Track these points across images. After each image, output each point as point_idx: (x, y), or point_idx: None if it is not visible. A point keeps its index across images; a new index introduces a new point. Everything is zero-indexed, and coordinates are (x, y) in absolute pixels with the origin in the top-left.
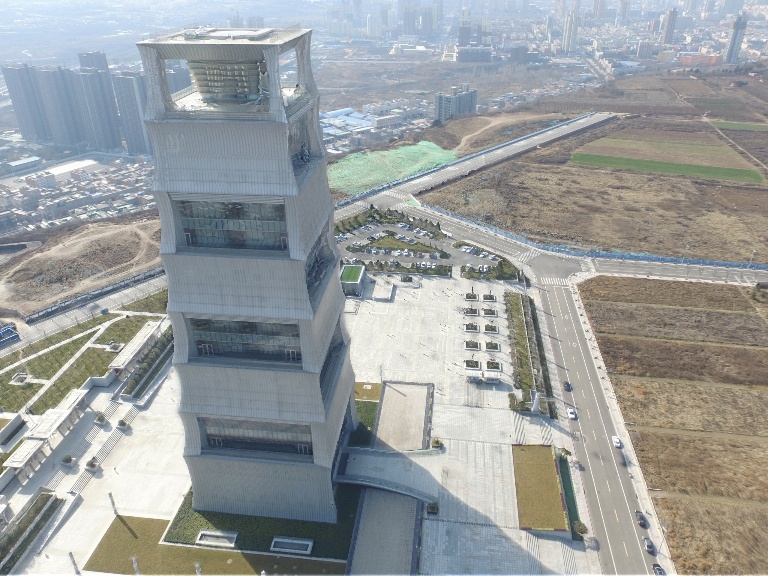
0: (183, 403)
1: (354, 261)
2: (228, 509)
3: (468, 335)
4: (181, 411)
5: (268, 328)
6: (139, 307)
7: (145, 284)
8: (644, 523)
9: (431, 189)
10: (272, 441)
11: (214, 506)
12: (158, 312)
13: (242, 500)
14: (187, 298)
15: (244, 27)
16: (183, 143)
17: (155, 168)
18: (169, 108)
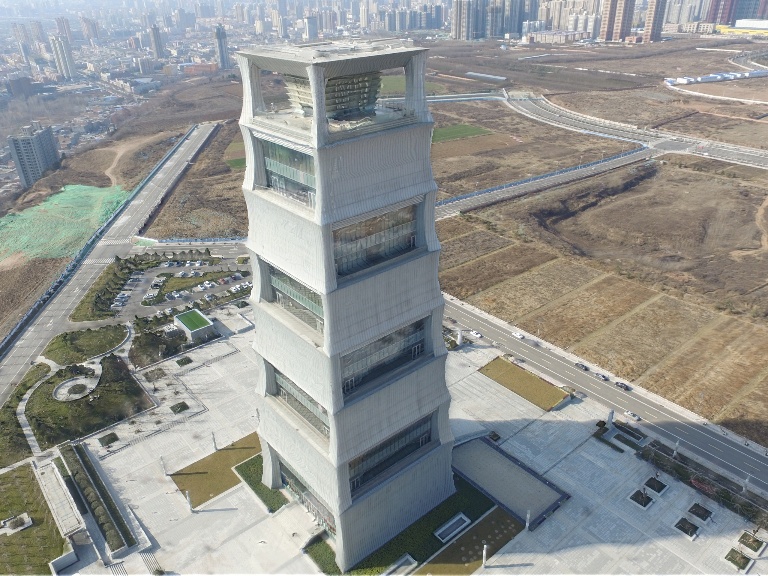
0: (340, 455)
1: (171, 311)
2: (375, 546)
3: None
4: (339, 465)
5: (401, 333)
6: None
7: None
8: (586, 367)
9: (145, 225)
10: (394, 452)
11: (363, 553)
12: (13, 462)
13: (386, 527)
14: (347, 333)
15: (394, 36)
16: (341, 166)
17: (322, 200)
18: (329, 131)
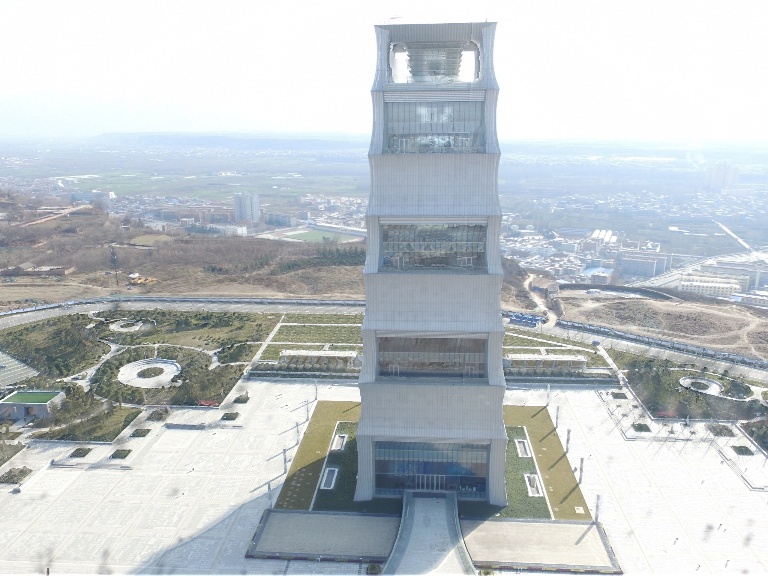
0: None
1: None
2: None
3: None
4: None
5: None
6: (616, 354)
7: (661, 350)
8: None
9: None
10: None
11: None
12: (617, 364)
13: None
14: None
15: None
16: None
17: None
18: None
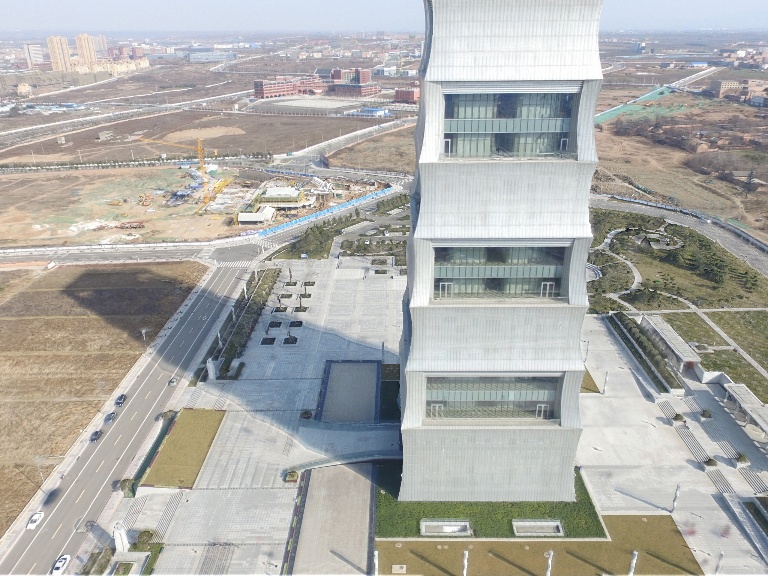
0: None
1: None
2: None
3: None
4: None
5: None
6: None
7: None
8: None
9: None
10: None
11: None
12: None
13: None
14: None
15: None
16: None
17: None
18: None
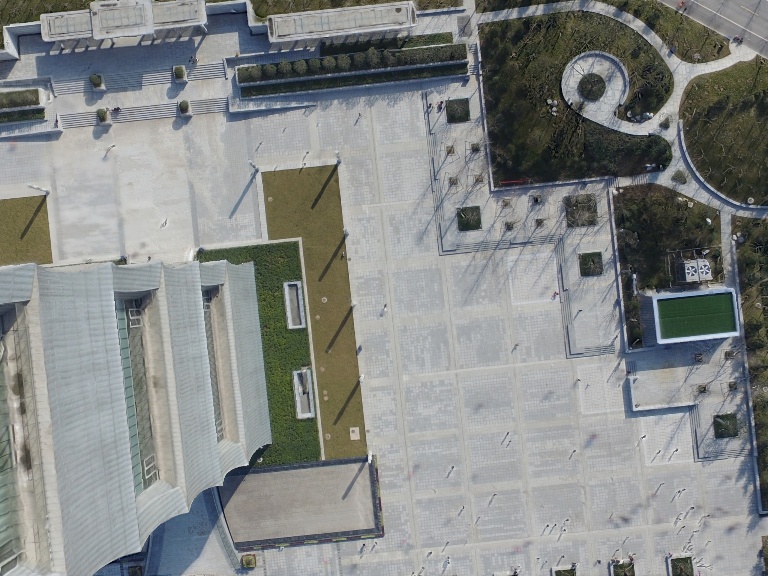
0: None
1: None
2: None
3: (541, 574)
4: None
5: None
6: None
7: None
8: None
9: None
10: None
11: None
12: None
13: None
14: None
15: None
16: None
17: None
18: None
